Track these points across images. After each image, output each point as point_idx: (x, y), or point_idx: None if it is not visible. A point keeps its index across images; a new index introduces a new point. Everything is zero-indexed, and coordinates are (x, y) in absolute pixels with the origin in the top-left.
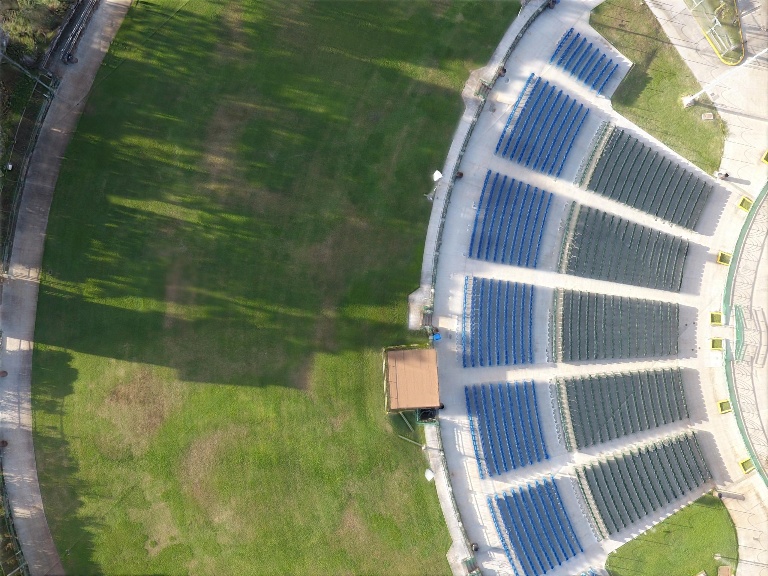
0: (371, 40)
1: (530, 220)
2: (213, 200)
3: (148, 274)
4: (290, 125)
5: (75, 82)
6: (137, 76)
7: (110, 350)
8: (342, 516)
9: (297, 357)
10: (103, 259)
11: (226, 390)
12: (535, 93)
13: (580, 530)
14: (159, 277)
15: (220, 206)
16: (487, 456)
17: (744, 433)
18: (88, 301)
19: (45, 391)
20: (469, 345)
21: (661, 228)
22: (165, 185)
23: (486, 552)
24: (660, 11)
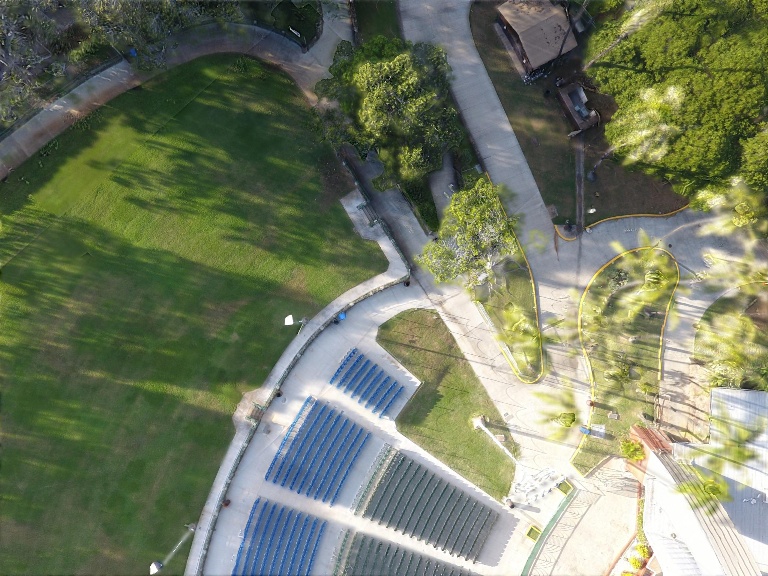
0: (135, 363)
1: (299, 552)
2: None
3: None
4: (42, 454)
5: None
6: None
7: None
8: None
9: None
10: None
11: None
12: (312, 416)
13: None
14: None
15: None
16: None
17: None
18: None
19: None
20: None
21: (442, 558)
22: None
23: None
24: (455, 325)
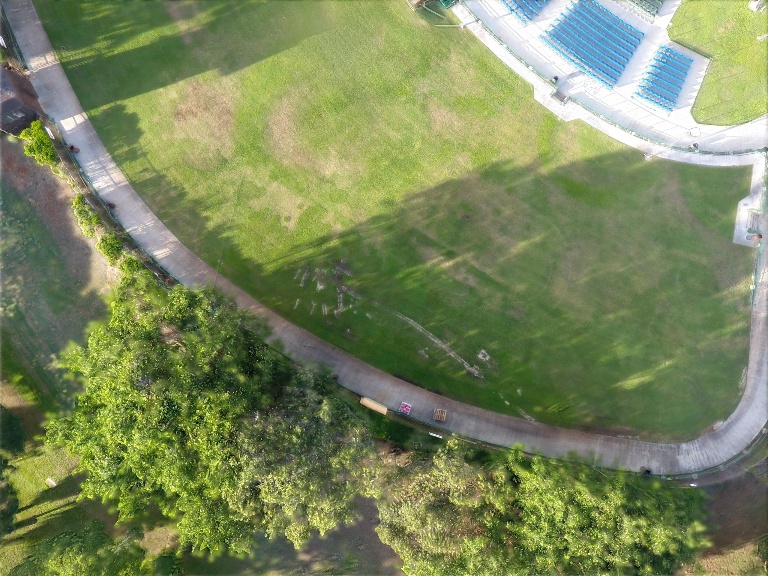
0: None
1: None
2: None
3: (146, 8)
4: None
5: None
6: None
7: (153, 84)
8: (429, 114)
9: (312, 7)
10: (101, 15)
11: (270, 63)
12: None
13: (631, 23)
14: (157, 6)
15: None
16: (518, 3)
17: None
18: (110, 55)
19: (119, 145)
20: None
21: None
22: None
23: (566, 82)
24: None
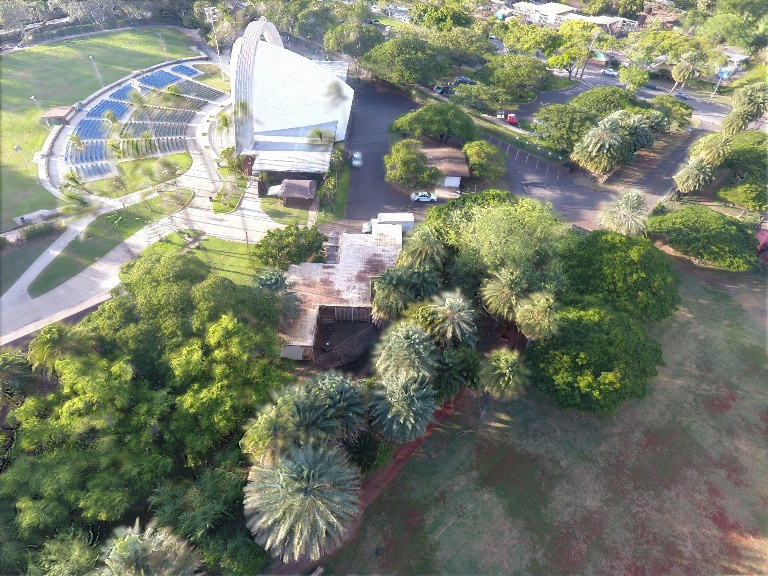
0: (103, 61)
1: None
2: None
3: None
4: (58, 70)
5: None
6: None
7: None
8: None
9: (12, 105)
10: None
11: None
12: None
13: None
14: None
15: None
16: (79, 133)
17: None
18: None
19: None
20: None
21: None
22: None
23: (57, 156)
24: (222, 67)
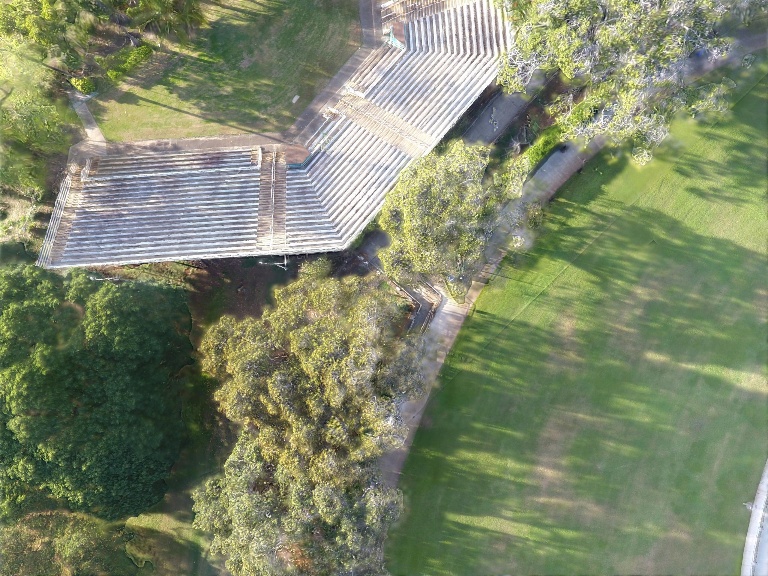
0: (697, 346)
1: None
2: (542, 514)
3: None
4: (617, 435)
5: None
6: (472, 387)
7: None
8: None
9: None
10: None
11: None
12: None
13: None
14: None
15: (548, 520)
16: None
17: None
18: None
19: None
20: None
21: None
22: (497, 499)
23: None
24: None
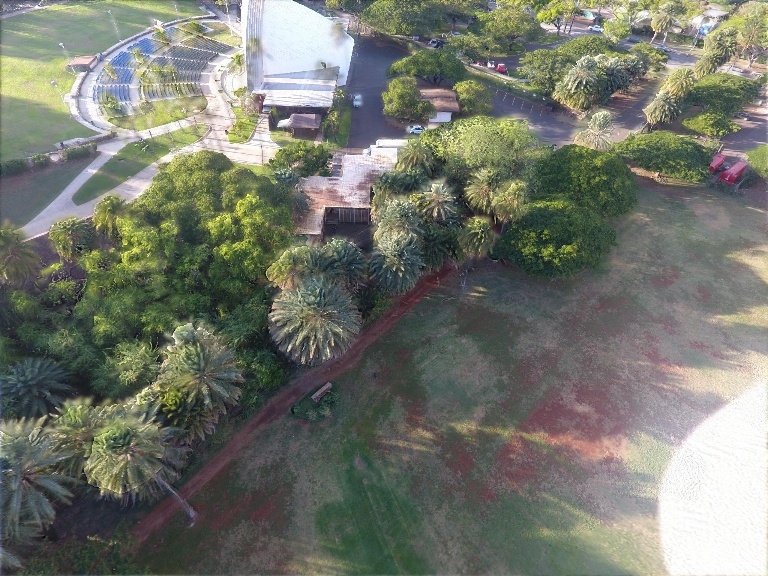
0: None
1: None
2: None
3: None
4: (78, 26)
5: (8, 15)
6: None
7: None
8: None
9: None
10: None
11: None
12: None
13: (133, 97)
14: None
15: None
16: (103, 79)
17: (224, 86)
18: None
19: None
20: (113, 61)
21: None
22: (22, 29)
23: (85, 97)
24: None
